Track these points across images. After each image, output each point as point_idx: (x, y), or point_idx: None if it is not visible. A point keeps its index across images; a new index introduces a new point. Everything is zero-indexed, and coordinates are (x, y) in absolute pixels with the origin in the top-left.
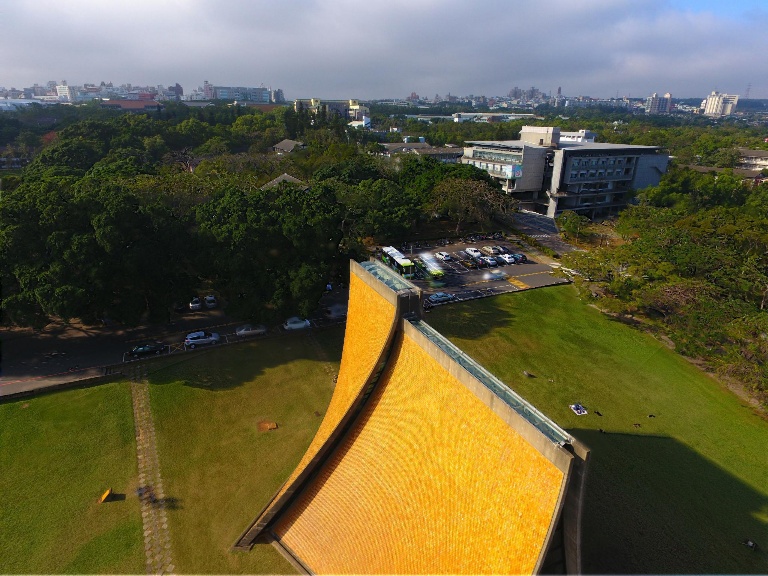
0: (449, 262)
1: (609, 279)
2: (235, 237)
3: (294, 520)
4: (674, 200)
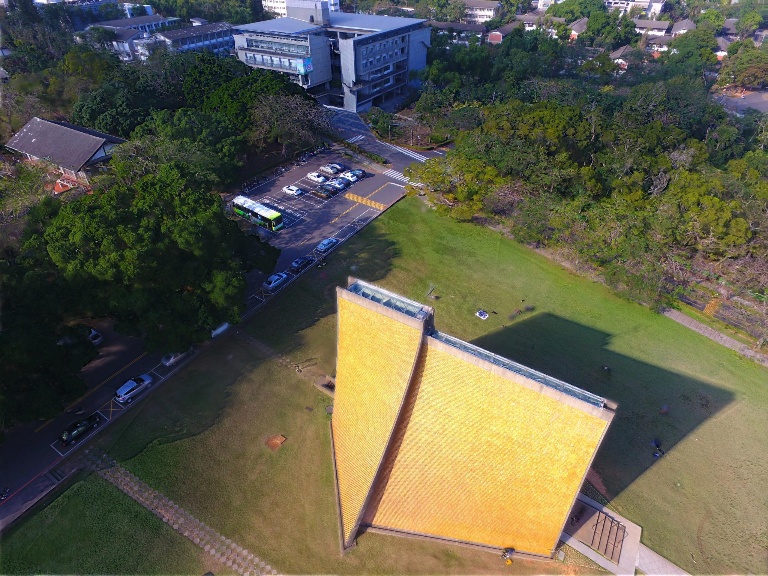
0: (301, 196)
1: None
2: (126, 270)
3: (377, 507)
4: (449, 79)
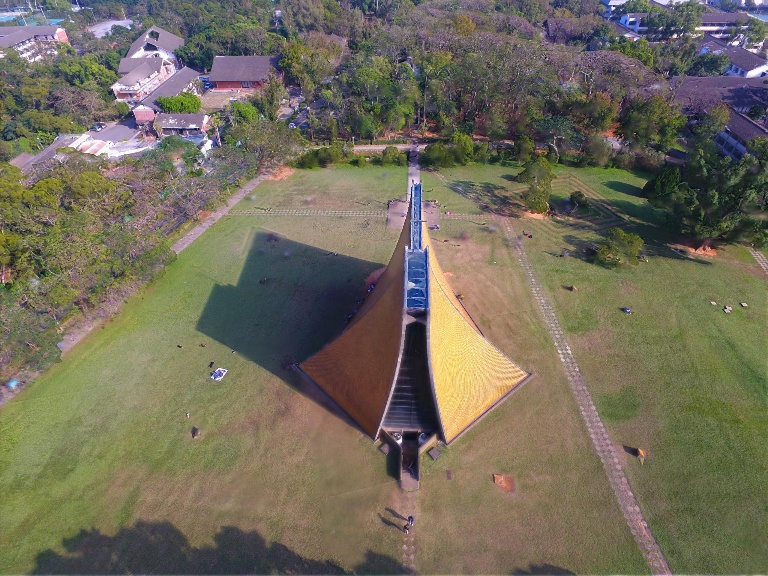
0: None
1: None
2: None
3: None
4: None
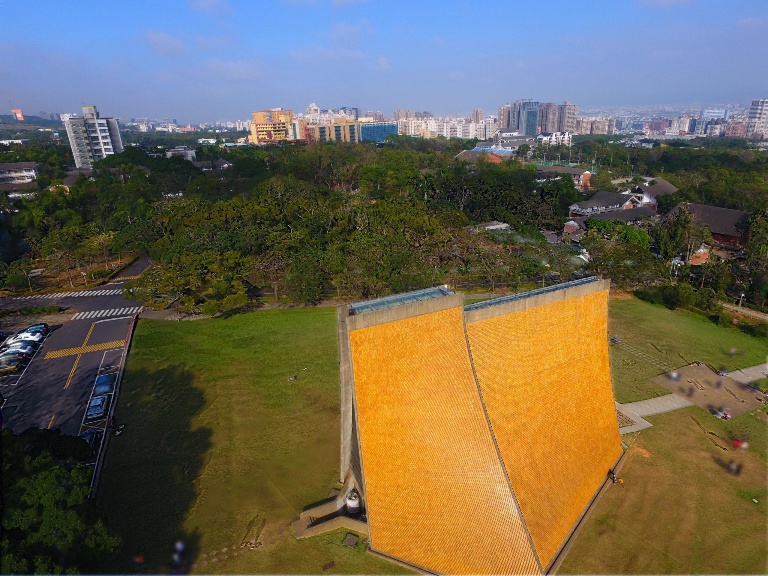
0: None
1: (187, 289)
2: None
3: None
4: (62, 218)
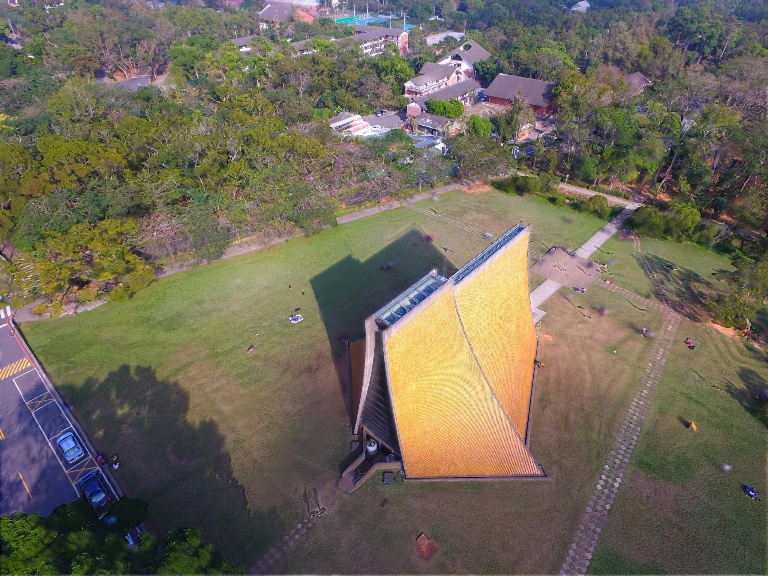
0: None
1: None
2: None
3: None
4: None
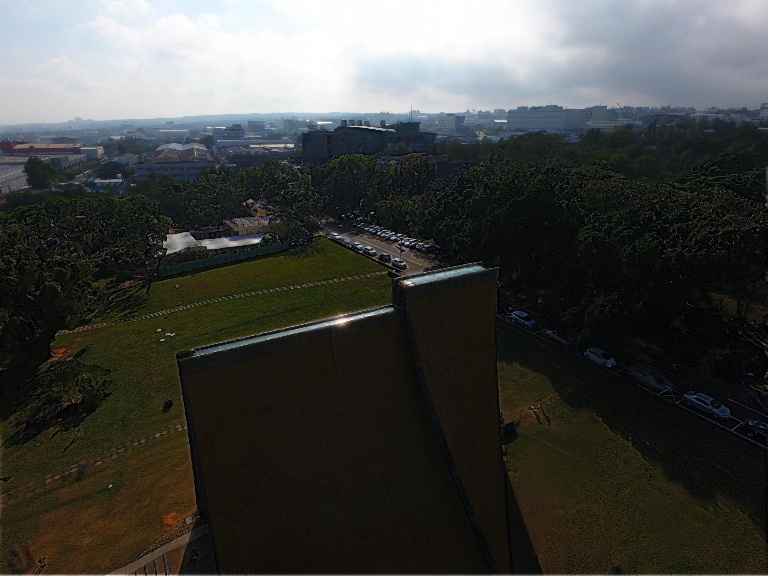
0: None
1: None
2: None
3: None
4: None
